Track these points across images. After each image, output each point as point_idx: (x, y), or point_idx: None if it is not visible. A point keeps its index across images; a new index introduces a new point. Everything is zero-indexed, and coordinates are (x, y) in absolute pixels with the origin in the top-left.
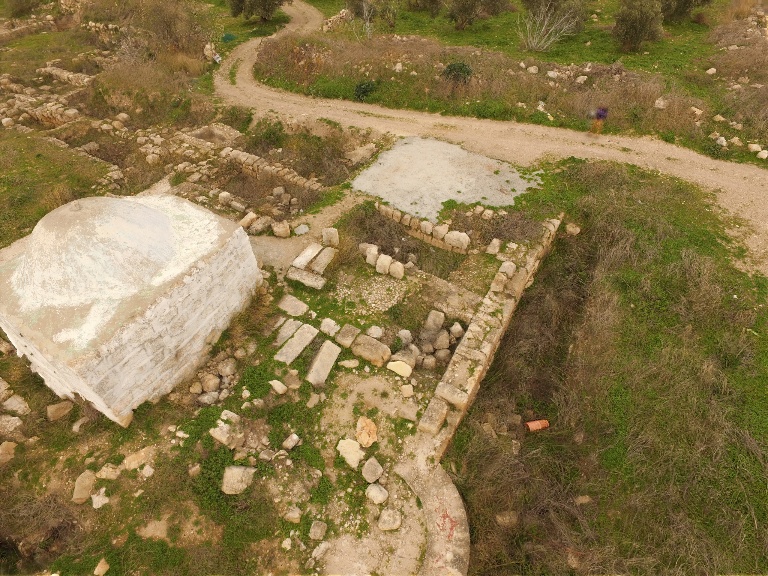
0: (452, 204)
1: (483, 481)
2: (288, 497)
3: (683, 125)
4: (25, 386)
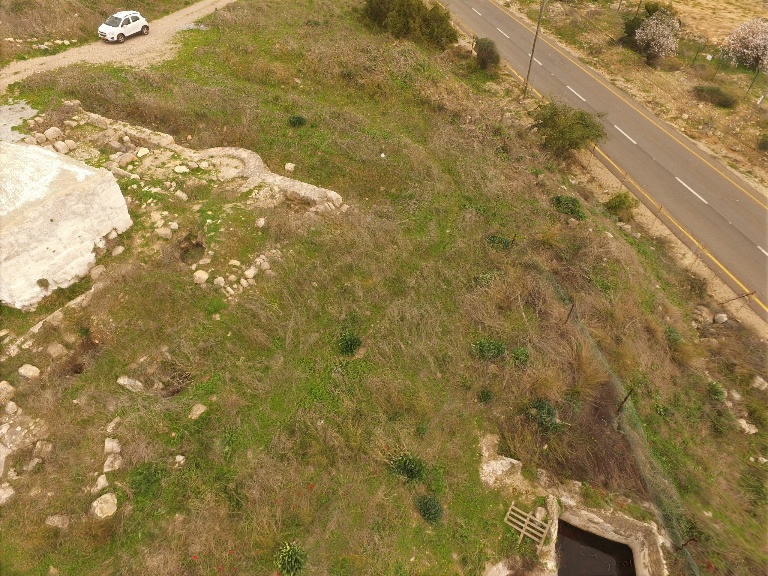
0: (18, 127)
1: (210, 141)
2: (196, 179)
3: (17, 49)
4: (62, 296)
